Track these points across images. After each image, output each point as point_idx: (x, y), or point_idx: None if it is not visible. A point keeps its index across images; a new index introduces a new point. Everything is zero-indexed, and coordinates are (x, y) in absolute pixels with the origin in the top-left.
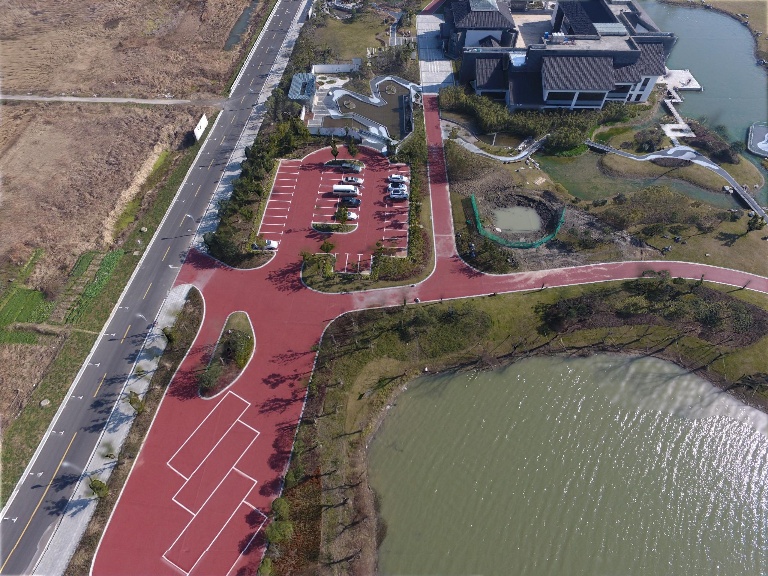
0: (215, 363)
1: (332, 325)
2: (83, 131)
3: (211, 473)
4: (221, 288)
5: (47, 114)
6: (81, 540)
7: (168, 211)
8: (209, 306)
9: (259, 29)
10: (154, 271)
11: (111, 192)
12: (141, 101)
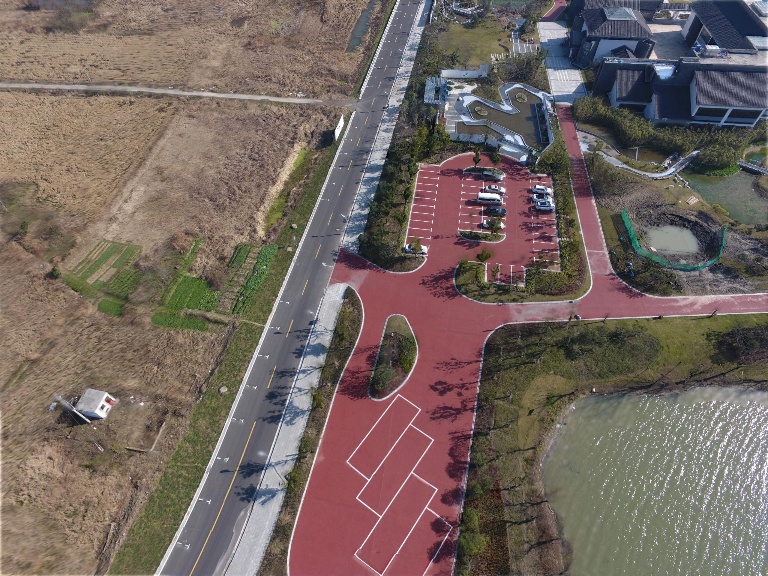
0: (381, 365)
1: (493, 336)
2: (224, 126)
3: (391, 476)
4: (376, 290)
5: (189, 108)
6: (274, 529)
7: (315, 209)
8: (367, 307)
9: (380, 31)
10: (309, 268)
11: (258, 187)
12: (275, 99)
